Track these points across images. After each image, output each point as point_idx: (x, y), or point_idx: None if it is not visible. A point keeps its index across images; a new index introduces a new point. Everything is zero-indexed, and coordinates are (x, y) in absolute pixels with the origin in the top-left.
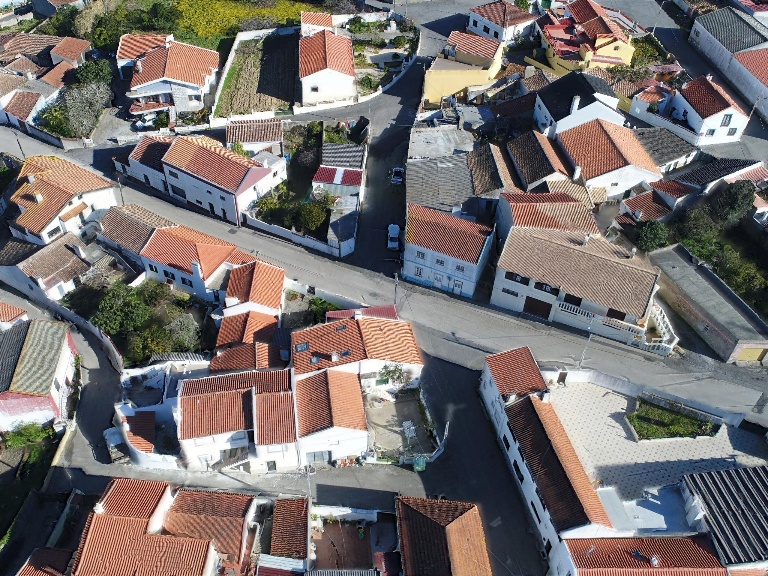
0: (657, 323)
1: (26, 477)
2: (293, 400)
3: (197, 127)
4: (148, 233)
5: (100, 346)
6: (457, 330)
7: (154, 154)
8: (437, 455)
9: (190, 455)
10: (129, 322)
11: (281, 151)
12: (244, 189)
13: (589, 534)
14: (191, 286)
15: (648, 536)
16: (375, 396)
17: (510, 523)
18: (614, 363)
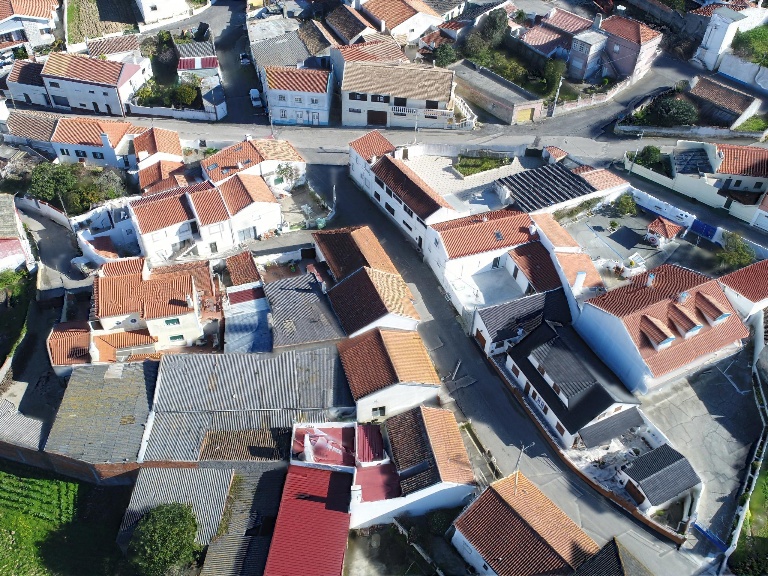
0: (461, 109)
1: (17, 305)
2: (219, 193)
3: None
4: (53, 124)
5: (40, 215)
6: (323, 145)
7: (30, 74)
8: (332, 216)
9: (150, 251)
10: (62, 186)
11: (141, 56)
12: (123, 83)
13: (443, 218)
14: (102, 158)
15: (480, 213)
16: (276, 194)
17: (392, 240)
18: (438, 140)
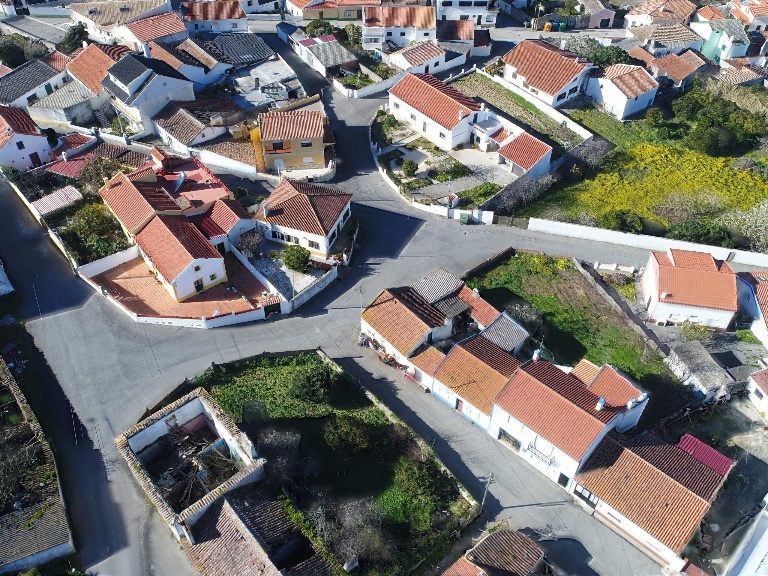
0: None
1: None
2: None
3: (483, 69)
4: None
5: None
6: None
7: None
8: None
9: None
10: None
11: None
12: None
13: None
14: None
15: None
16: None
17: None
18: None
